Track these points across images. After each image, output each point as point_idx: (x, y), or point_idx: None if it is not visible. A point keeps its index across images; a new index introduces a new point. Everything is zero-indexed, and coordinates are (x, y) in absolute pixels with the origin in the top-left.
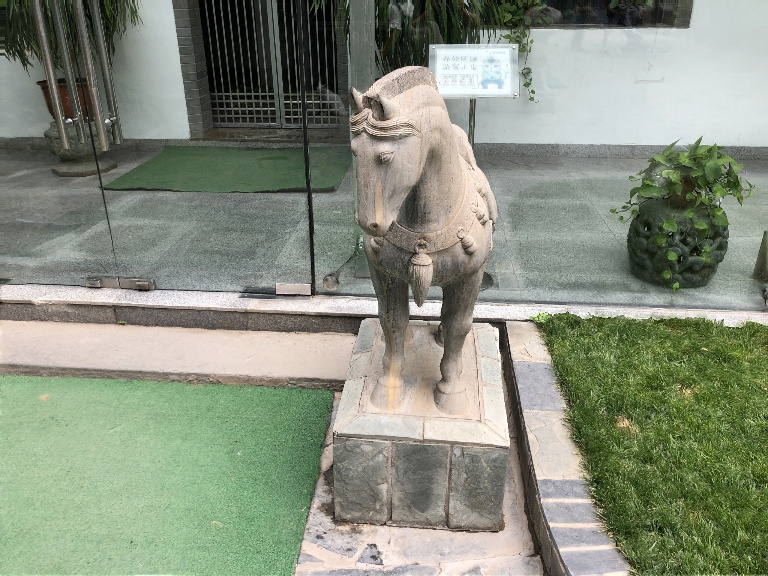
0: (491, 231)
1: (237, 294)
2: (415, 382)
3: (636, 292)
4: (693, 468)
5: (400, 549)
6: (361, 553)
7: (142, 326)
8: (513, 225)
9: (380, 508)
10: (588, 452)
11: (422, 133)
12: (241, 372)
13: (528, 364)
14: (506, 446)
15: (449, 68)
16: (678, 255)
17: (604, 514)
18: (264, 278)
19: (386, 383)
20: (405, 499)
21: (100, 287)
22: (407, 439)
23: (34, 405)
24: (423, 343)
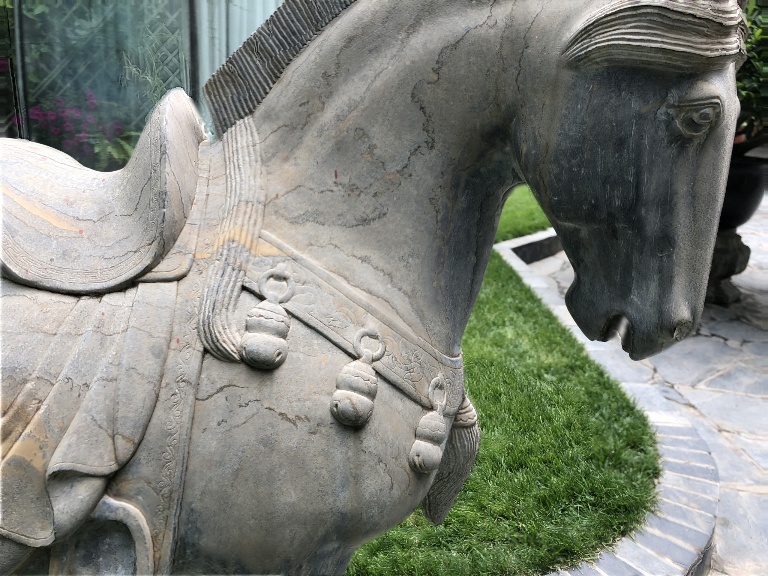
0: None
1: None
2: None
3: None
4: None
5: None
6: None
7: None
8: None
9: None
10: None
11: None
12: None
13: None
14: None
15: None
16: None
17: None
18: None
19: None
20: None
21: None
22: None
23: None
24: None
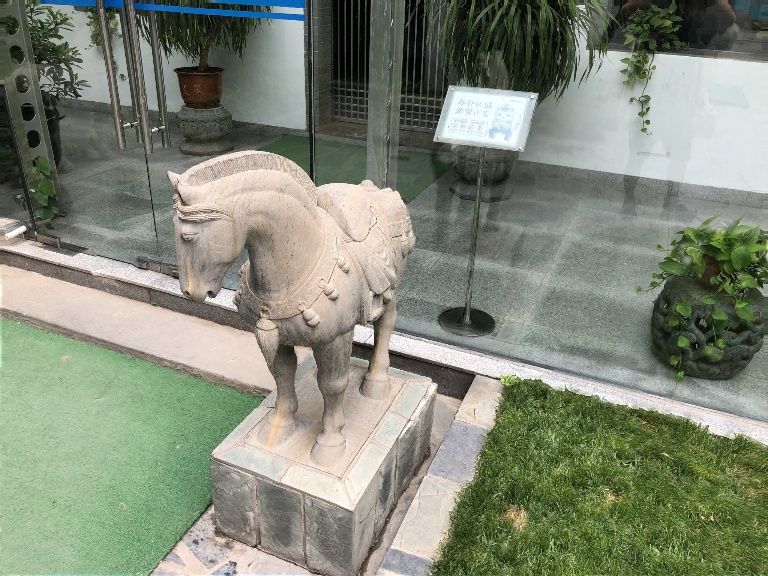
0: (371, 302)
1: None
2: (309, 424)
3: (639, 371)
4: None
5: (255, 574)
6: (219, 567)
7: (169, 310)
8: (561, 269)
9: (250, 532)
10: (454, 534)
11: (235, 217)
12: (218, 371)
13: (466, 426)
14: (349, 509)
15: (462, 112)
16: (691, 341)
17: None
18: None
19: (271, 421)
20: (270, 530)
21: (146, 269)
22: (267, 478)
23: (54, 364)
24: (347, 386)
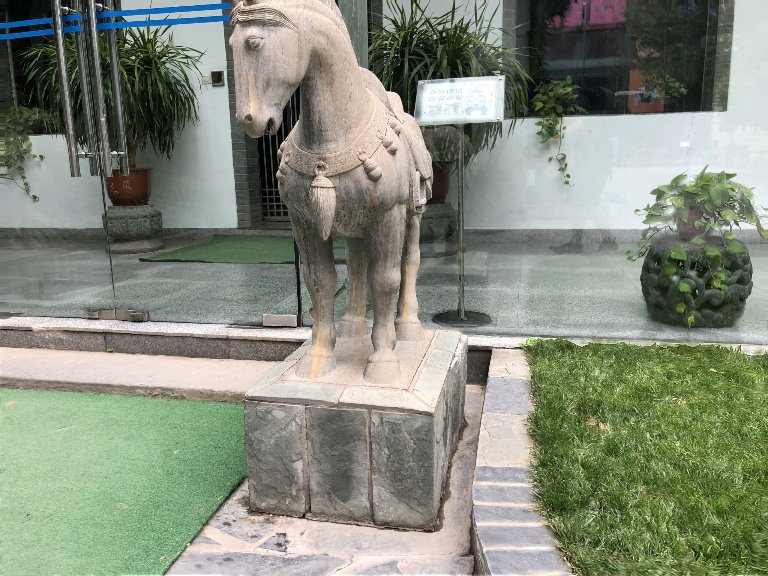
0: (418, 183)
1: (225, 325)
2: (350, 361)
3: (648, 330)
4: (667, 462)
5: (312, 540)
6: (266, 540)
7: (129, 354)
8: (531, 285)
9: (297, 494)
10: (542, 443)
11: (300, 29)
12: (205, 387)
13: (504, 379)
14: (429, 412)
15: (435, 100)
16: (692, 288)
17: (540, 493)
18: (257, 316)
19: (311, 351)
20: (324, 483)
21: (98, 318)
22: (321, 403)
23: None
24: None
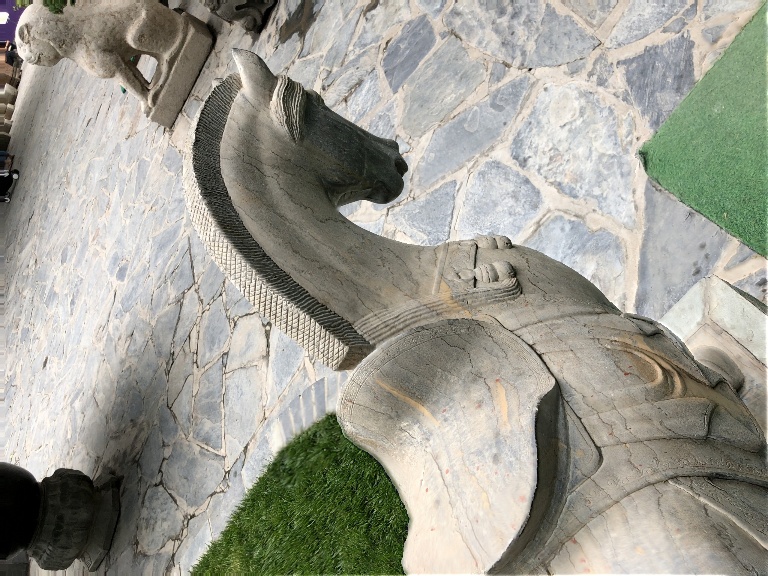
0: None
1: None
2: None
3: None
4: None
5: None
6: None
7: None
8: None
9: None
10: None
11: None
12: None
13: None
14: None
15: None
16: None
17: None
18: None
19: None
20: None
21: None
22: None
23: None
24: None
